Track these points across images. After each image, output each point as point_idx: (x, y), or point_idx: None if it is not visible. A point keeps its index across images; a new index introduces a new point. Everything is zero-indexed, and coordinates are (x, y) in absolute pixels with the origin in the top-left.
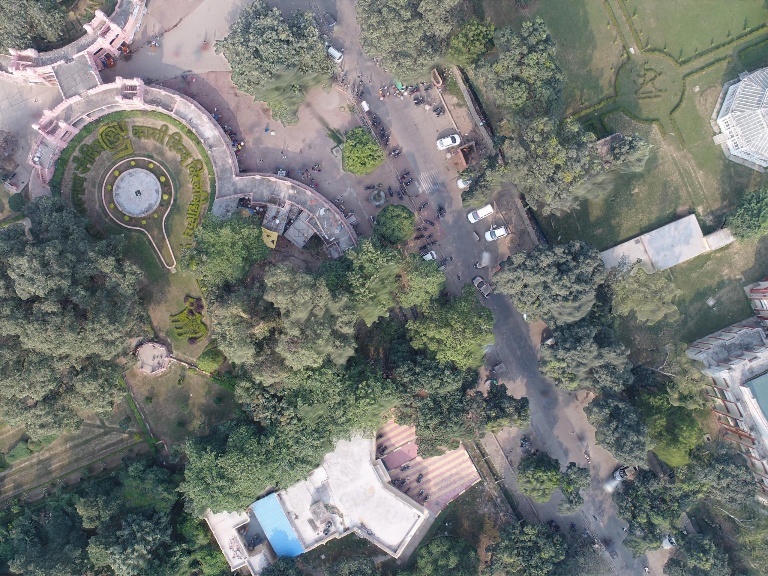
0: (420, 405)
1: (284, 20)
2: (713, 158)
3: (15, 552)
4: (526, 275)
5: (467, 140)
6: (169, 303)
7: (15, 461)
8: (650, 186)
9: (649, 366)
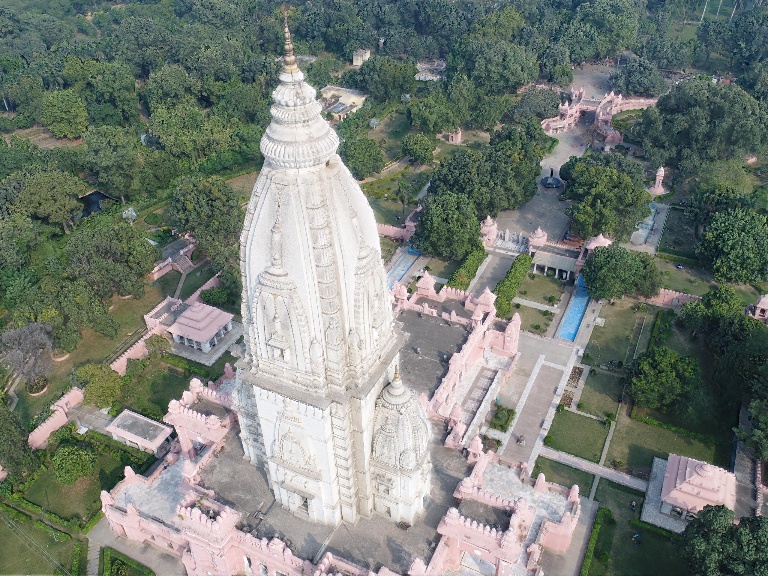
0: None
1: None
2: None
3: None
4: None
5: None
6: None
7: (767, 208)
8: None
9: None
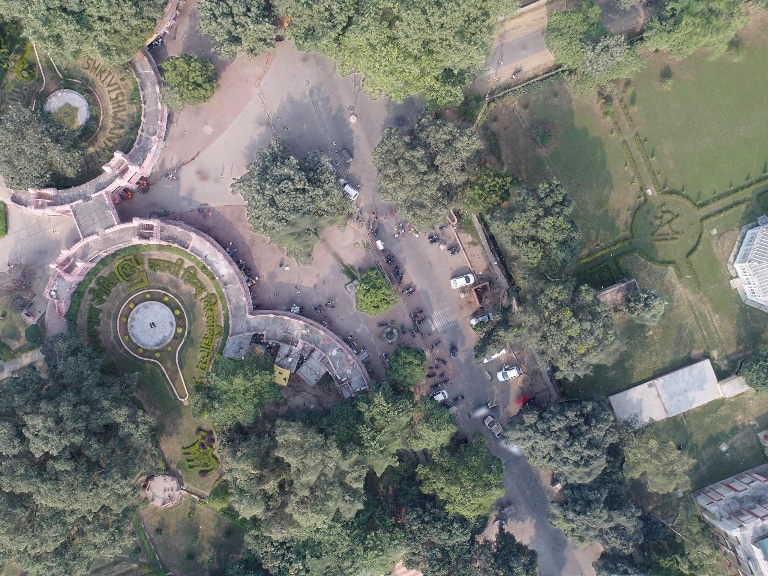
0: (428, 555)
1: (301, 161)
2: (729, 302)
3: None
4: (537, 438)
5: (481, 279)
6: (181, 435)
7: None
8: (665, 329)
9: (660, 510)
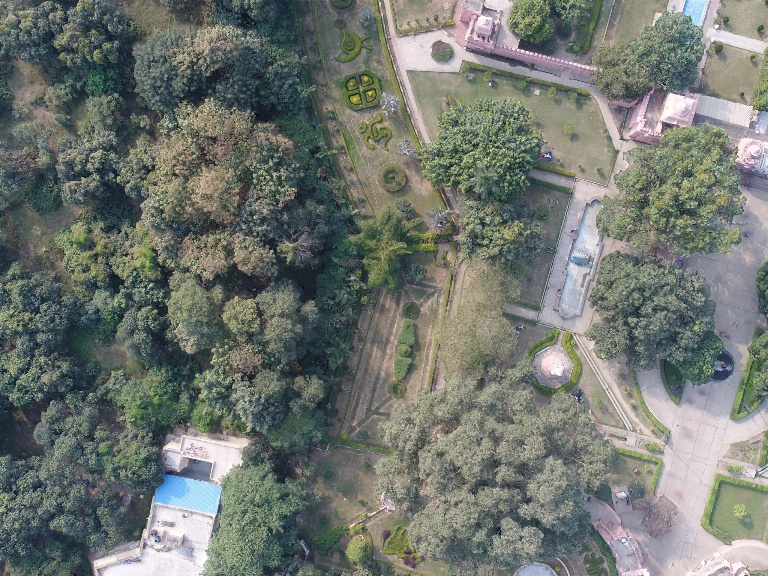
0: None
1: None
2: None
3: (332, 276)
4: None
5: None
6: None
7: None
8: None
9: None
